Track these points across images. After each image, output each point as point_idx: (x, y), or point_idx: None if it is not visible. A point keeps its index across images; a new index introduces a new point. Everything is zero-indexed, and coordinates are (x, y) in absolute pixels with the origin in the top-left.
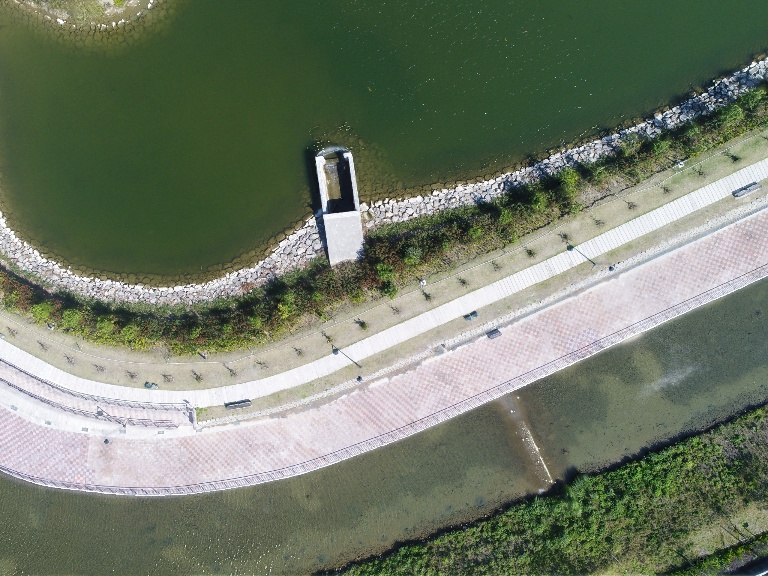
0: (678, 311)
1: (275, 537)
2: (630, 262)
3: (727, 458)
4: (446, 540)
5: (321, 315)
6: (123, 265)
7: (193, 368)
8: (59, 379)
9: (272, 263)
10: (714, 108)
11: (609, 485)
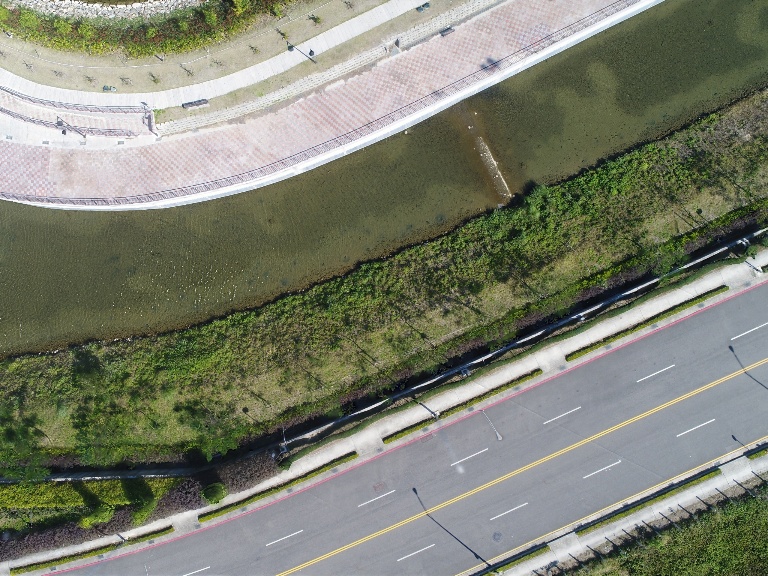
0: (628, 3)
1: (238, 262)
2: None
3: (681, 157)
4: (407, 254)
5: None
6: None
7: (150, 70)
8: (18, 86)
9: None
10: None
11: (566, 192)
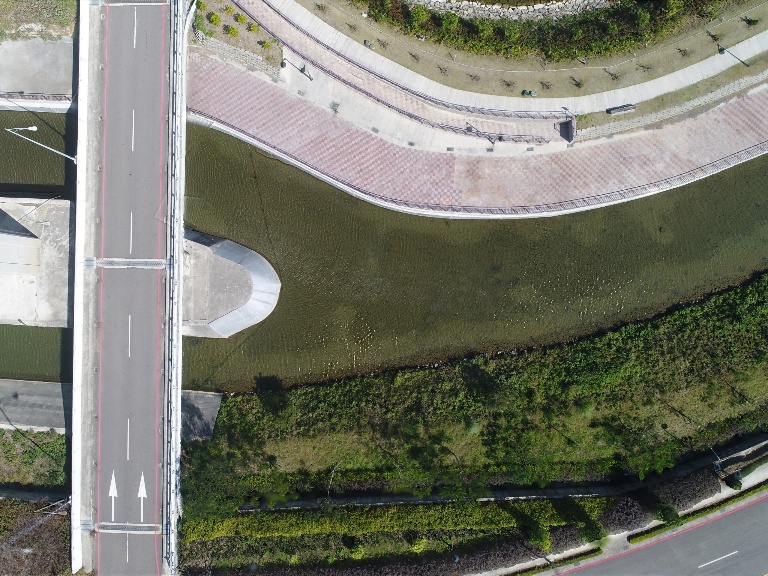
0: None
1: (627, 272)
2: None
3: None
4: None
5: (703, 16)
6: None
7: (572, 74)
8: (432, 90)
9: None
10: None
11: None
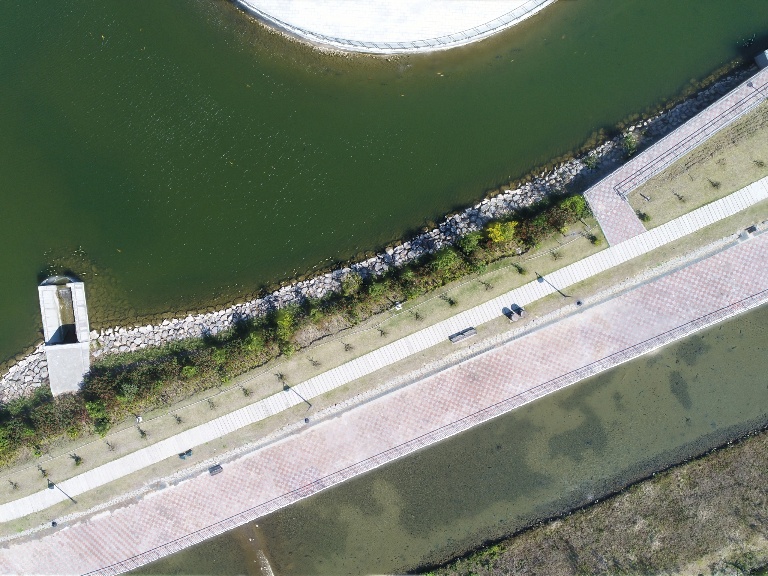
0: (400, 452)
1: None
2: (350, 402)
3: None
4: None
5: (39, 448)
6: None
7: None
8: None
9: (0, 389)
10: (440, 247)
11: None
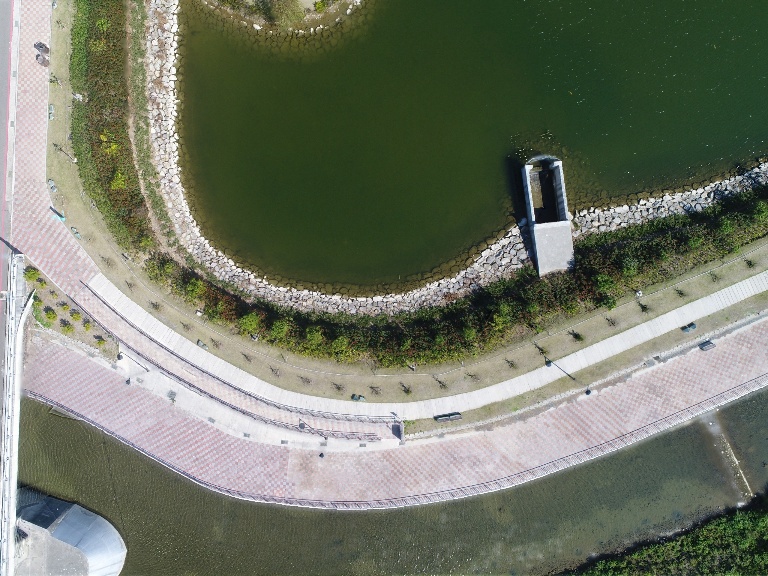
0: None
1: (466, 551)
2: None
3: None
4: (645, 554)
5: (532, 326)
6: (318, 275)
7: (401, 380)
8: (263, 391)
9: (475, 273)
10: None
11: None
